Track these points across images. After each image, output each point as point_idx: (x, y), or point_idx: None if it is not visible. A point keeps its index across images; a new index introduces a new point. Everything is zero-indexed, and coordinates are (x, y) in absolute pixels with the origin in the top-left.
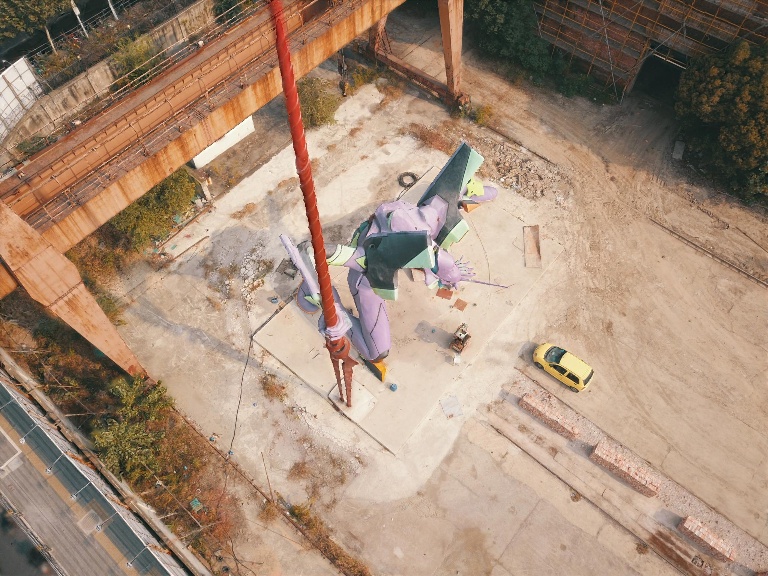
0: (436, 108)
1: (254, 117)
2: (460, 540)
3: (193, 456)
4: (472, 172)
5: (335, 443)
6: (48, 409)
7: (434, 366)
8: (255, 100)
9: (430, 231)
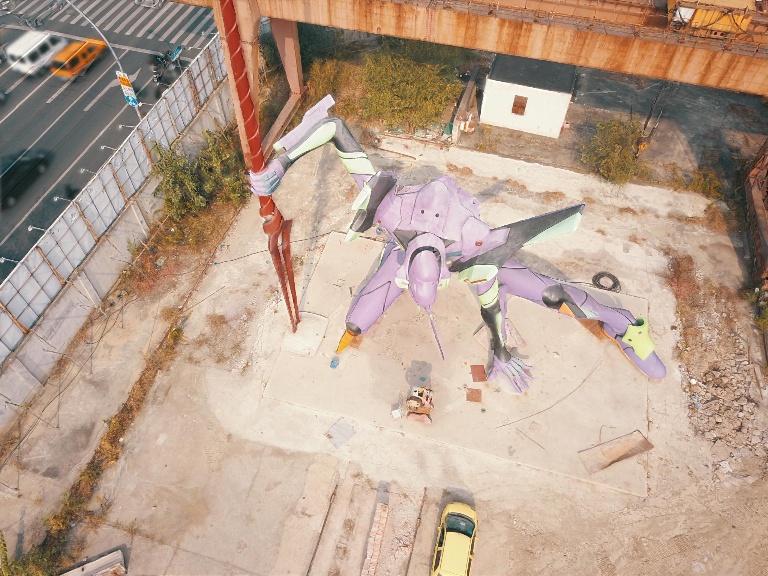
0: (737, 271)
1: (573, 132)
2: (191, 497)
3: (202, 240)
4: (552, 233)
5: (255, 339)
6: (191, 125)
7: (380, 395)
8: (497, 39)
9: (461, 246)
